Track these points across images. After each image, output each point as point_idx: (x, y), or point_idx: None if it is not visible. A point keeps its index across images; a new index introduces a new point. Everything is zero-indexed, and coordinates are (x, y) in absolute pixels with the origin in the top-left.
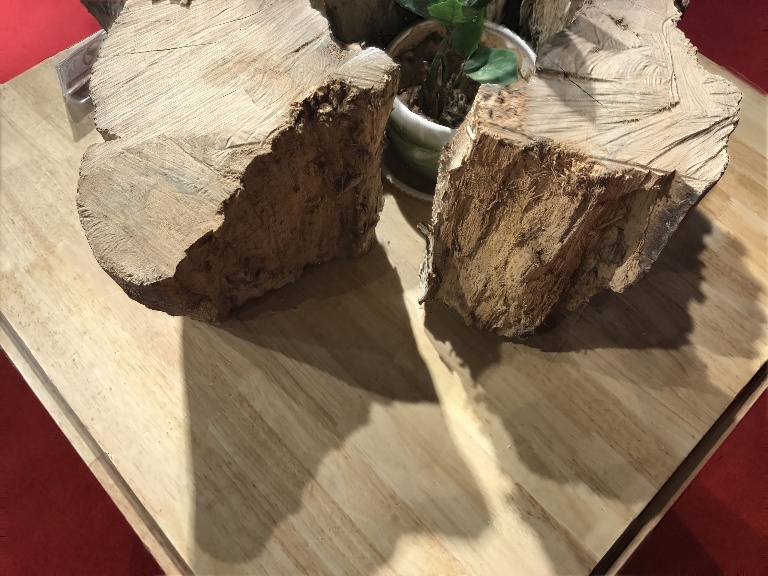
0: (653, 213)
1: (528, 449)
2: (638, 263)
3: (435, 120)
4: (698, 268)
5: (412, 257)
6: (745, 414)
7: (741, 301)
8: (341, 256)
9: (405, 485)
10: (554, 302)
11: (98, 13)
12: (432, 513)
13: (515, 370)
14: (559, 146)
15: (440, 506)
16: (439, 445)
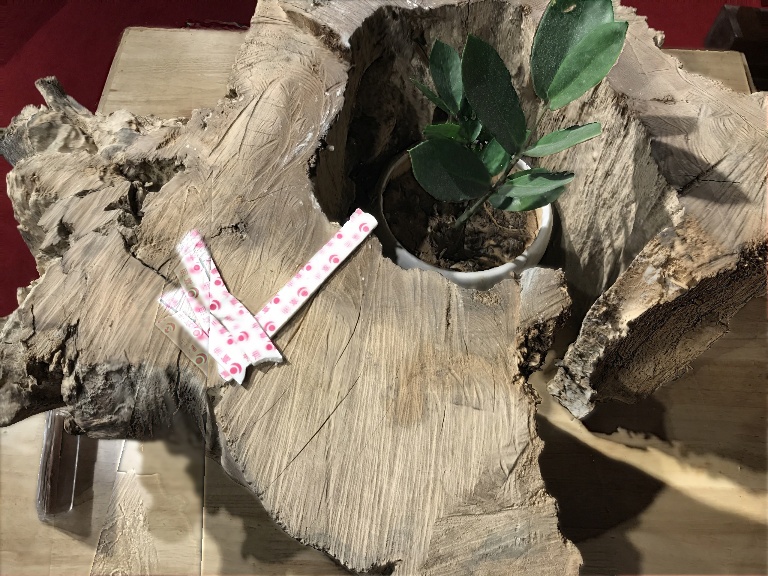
0: None
1: (751, 457)
2: None
3: (471, 260)
4: None
5: None
6: None
7: None
8: None
9: (715, 574)
10: None
11: None
12: (752, 575)
13: (681, 404)
14: (753, 243)
15: (750, 563)
16: (700, 517)
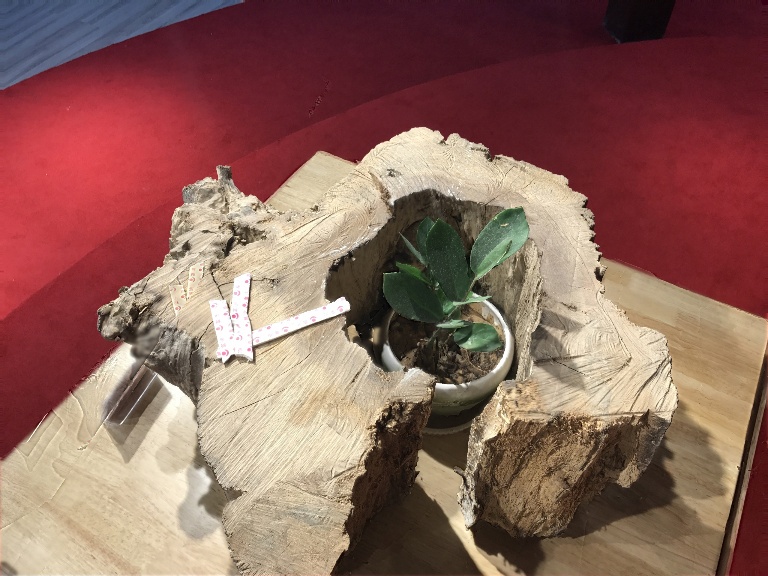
0: (640, 436)
1: None
2: (636, 467)
3: (436, 376)
4: None
5: (444, 486)
6: (736, 541)
7: (698, 448)
8: (389, 503)
9: None
10: (578, 504)
11: (167, 374)
12: None
13: (559, 562)
14: (569, 415)
15: None
16: None
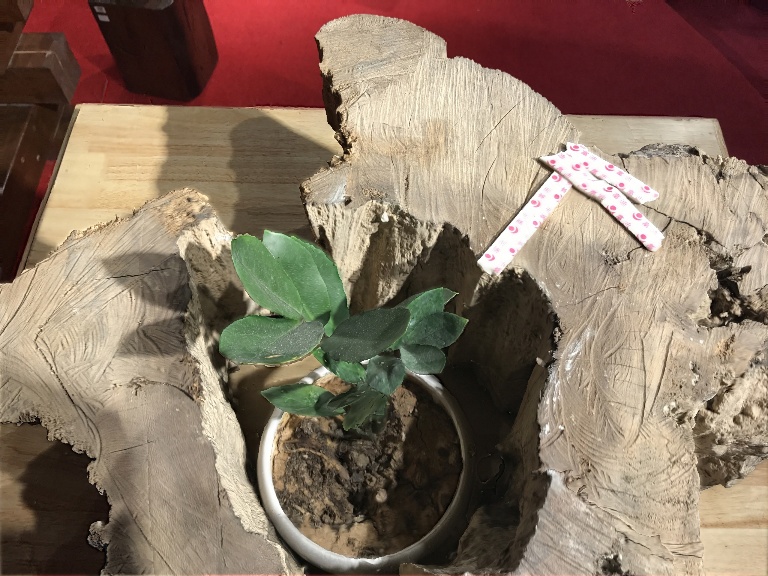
0: None
1: None
2: None
3: None
4: (41, 571)
5: None
6: None
7: None
8: None
9: None
10: None
11: None
12: None
13: None
14: None
15: None
16: None
